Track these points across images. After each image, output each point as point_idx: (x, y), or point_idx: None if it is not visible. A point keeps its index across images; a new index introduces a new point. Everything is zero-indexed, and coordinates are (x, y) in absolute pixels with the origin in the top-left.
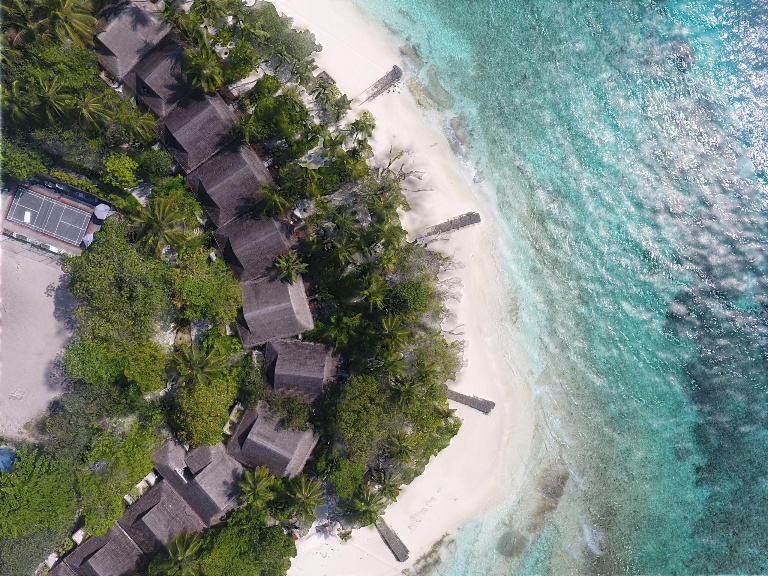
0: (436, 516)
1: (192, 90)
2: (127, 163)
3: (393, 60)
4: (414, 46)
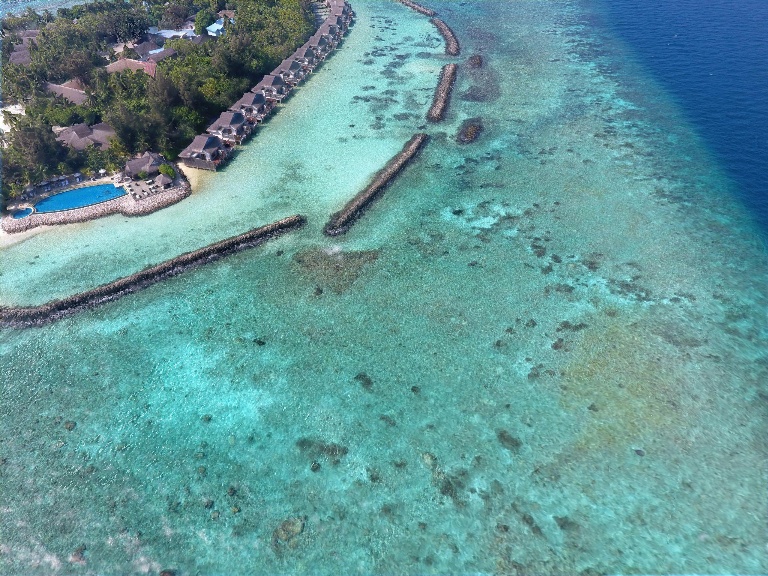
0: None
1: None
2: None
3: None
4: None
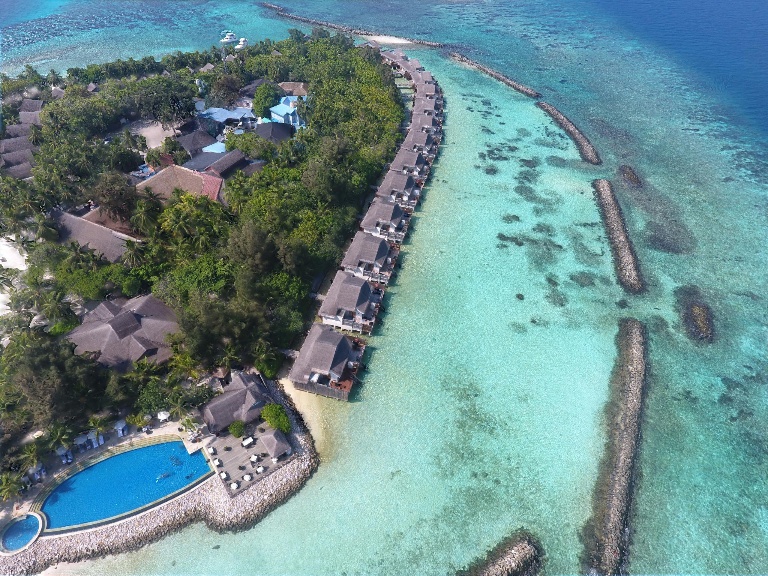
0: None
1: None
2: None
3: None
4: None
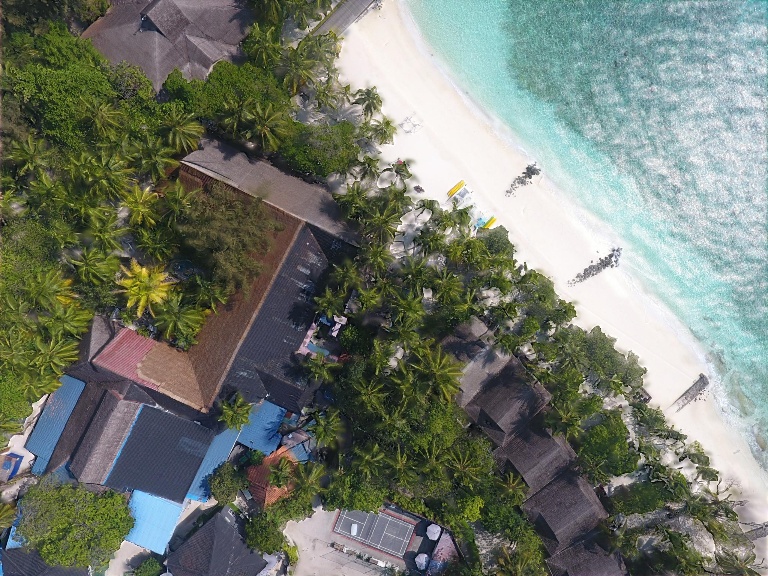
0: None
1: (529, 420)
2: (478, 504)
3: (697, 365)
4: (718, 353)
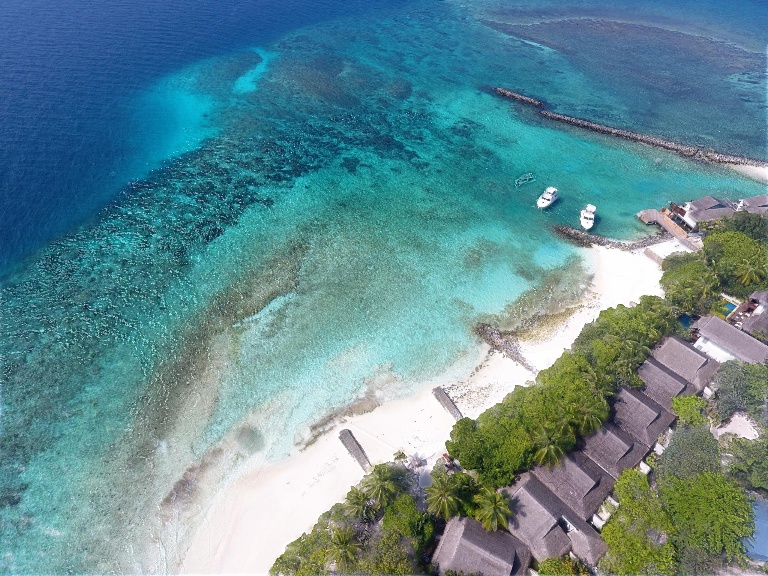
0: (310, 468)
1: None
2: None
3: None
4: None
